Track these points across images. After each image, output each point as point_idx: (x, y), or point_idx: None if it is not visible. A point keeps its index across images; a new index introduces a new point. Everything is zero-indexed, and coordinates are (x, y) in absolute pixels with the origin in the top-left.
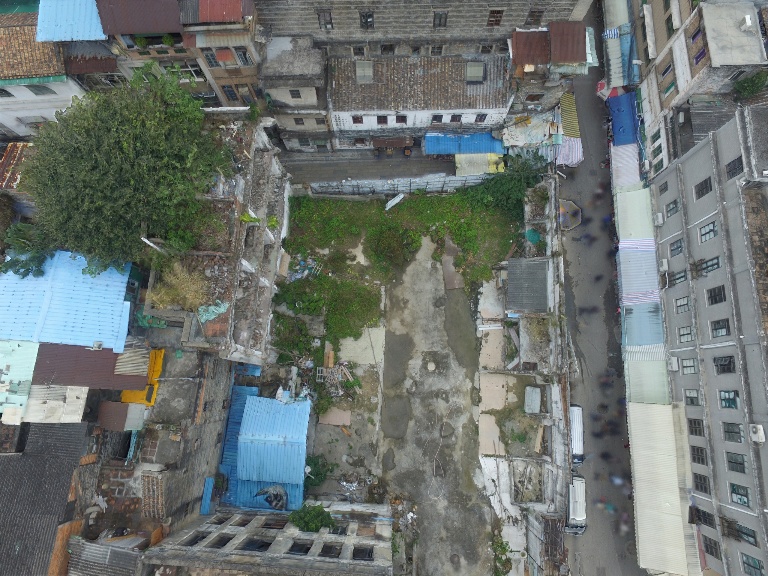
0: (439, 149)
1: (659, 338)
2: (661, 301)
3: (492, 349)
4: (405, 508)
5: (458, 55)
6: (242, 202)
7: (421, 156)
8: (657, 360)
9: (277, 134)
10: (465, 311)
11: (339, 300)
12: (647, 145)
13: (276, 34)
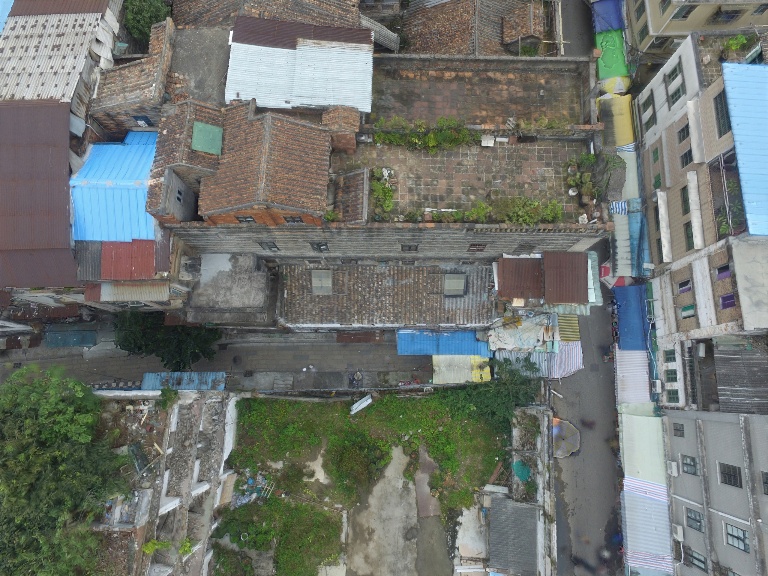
0: (414, 349)
1: None
2: (674, 574)
3: None
4: None
5: (434, 265)
6: (147, 519)
7: (395, 340)
8: None
9: (224, 328)
10: (441, 546)
11: (292, 531)
12: (659, 358)
13: (211, 252)
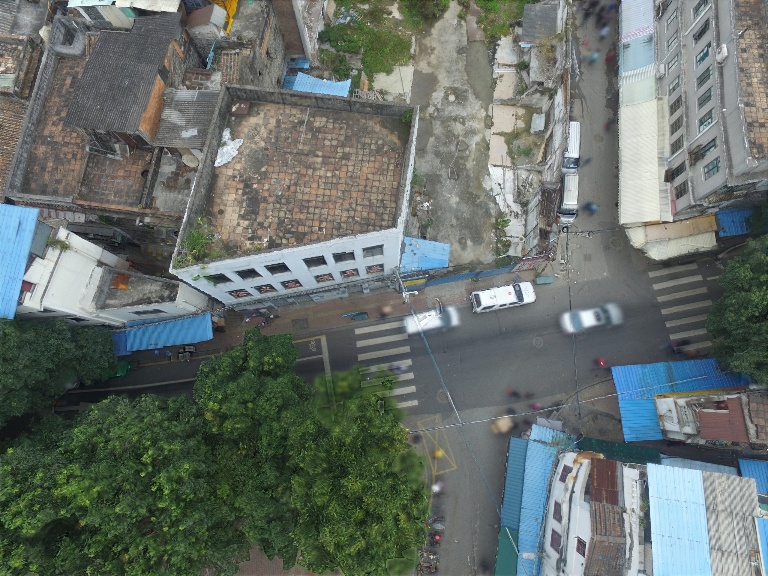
0: None
1: (651, 60)
2: (655, 30)
3: (505, 87)
4: (422, 199)
5: None
6: None
7: None
8: (648, 77)
9: None
10: (484, 58)
11: (375, 42)
12: None
13: None
